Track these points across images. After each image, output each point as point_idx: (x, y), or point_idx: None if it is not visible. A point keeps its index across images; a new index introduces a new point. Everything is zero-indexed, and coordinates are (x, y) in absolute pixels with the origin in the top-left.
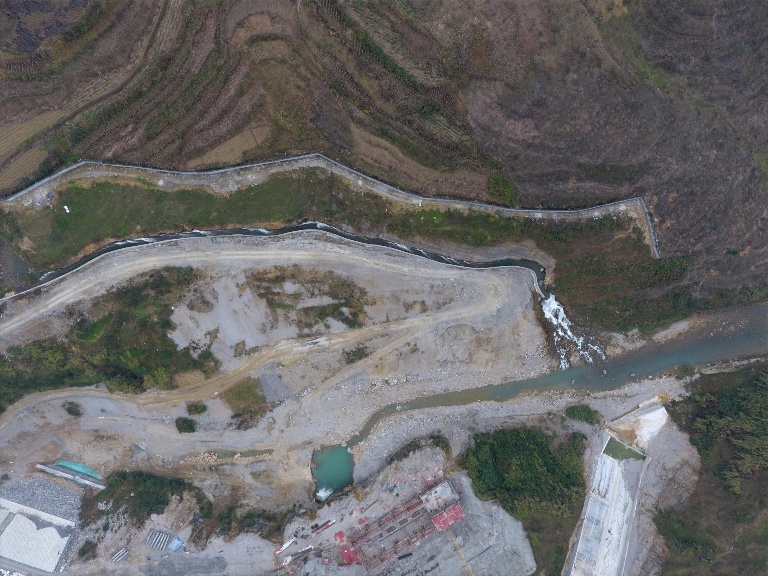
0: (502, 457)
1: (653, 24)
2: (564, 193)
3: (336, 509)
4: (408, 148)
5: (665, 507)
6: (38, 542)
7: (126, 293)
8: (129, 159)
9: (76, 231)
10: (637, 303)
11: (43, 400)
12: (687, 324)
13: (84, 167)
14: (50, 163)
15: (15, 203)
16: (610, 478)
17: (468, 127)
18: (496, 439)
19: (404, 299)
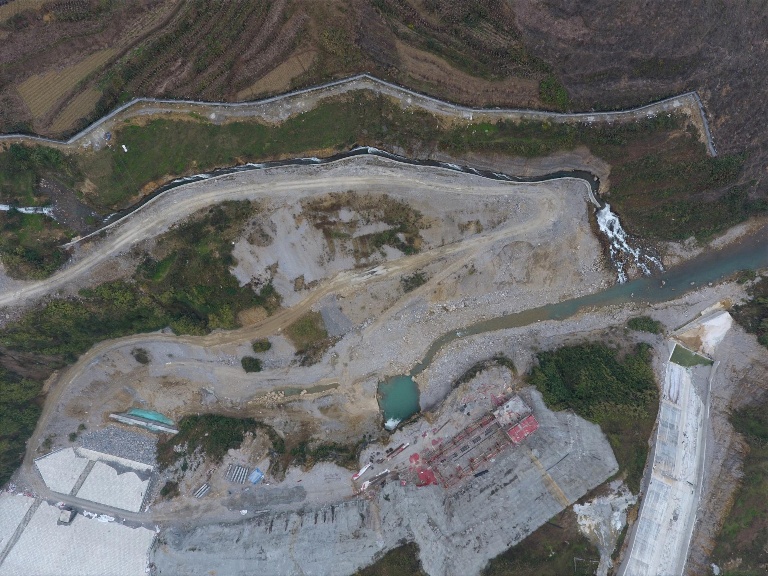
0: (569, 370)
1: None
2: (617, 93)
3: (408, 433)
4: (456, 60)
5: (740, 406)
6: (120, 486)
7: (188, 230)
8: (180, 94)
9: (135, 170)
10: (693, 207)
11: (112, 348)
12: (744, 228)
13: (138, 105)
14: (105, 102)
15: (75, 145)
16: (679, 384)
17: (516, 31)
18: (560, 356)
19: (459, 220)
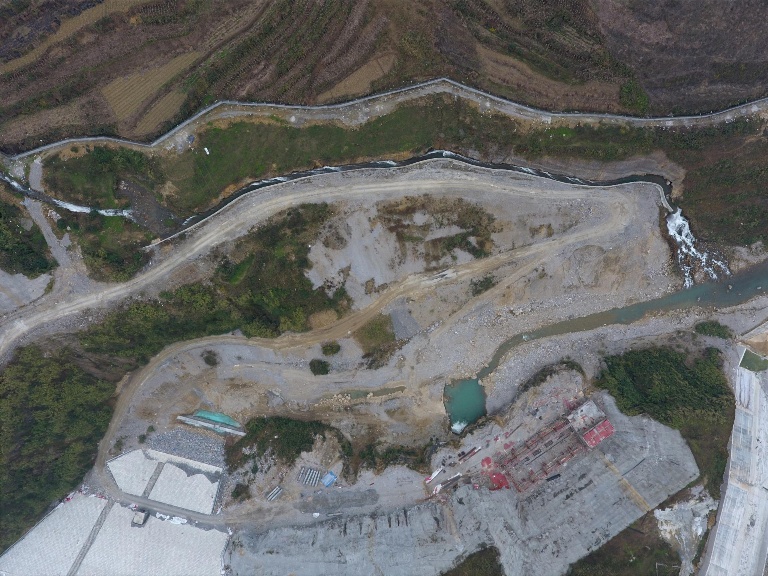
0: (641, 374)
1: None
2: (697, 97)
3: (480, 436)
4: (537, 64)
5: None
6: (191, 488)
7: (266, 233)
8: (262, 97)
9: (217, 173)
10: (764, 212)
11: (183, 350)
12: None
13: (220, 108)
14: (189, 105)
15: (158, 148)
16: (750, 389)
17: (600, 35)
18: (628, 360)
19: (531, 224)
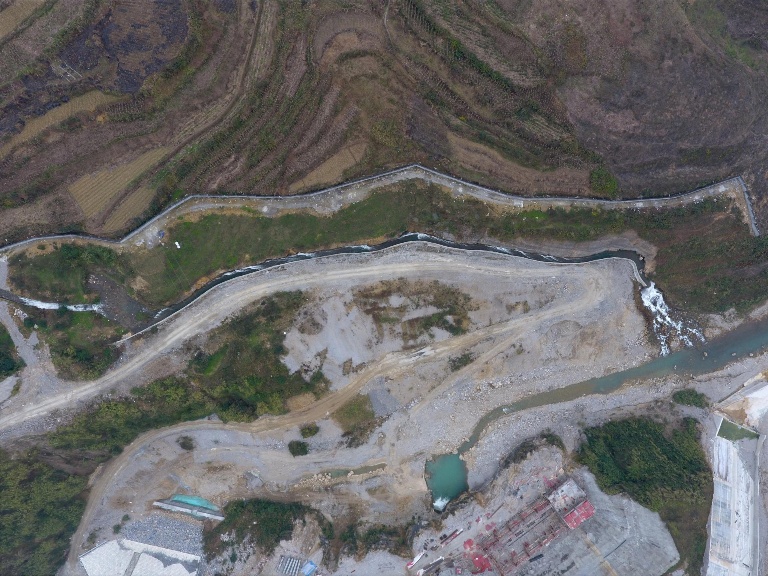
0: (620, 449)
1: (739, 3)
2: (665, 180)
3: (462, 518)
4: (507, 151)
5: None
6: None
7: (240, 323)
8: (233, 189)
9: (188, 266)
10: (735, 282)
11: (158, 437)
12: None
13: (191, 201)
14: (159, 201)
15: (127, 244)
16: (728, 460)
17: (568, 124)
18: (608, 432)
19: (507, 301)
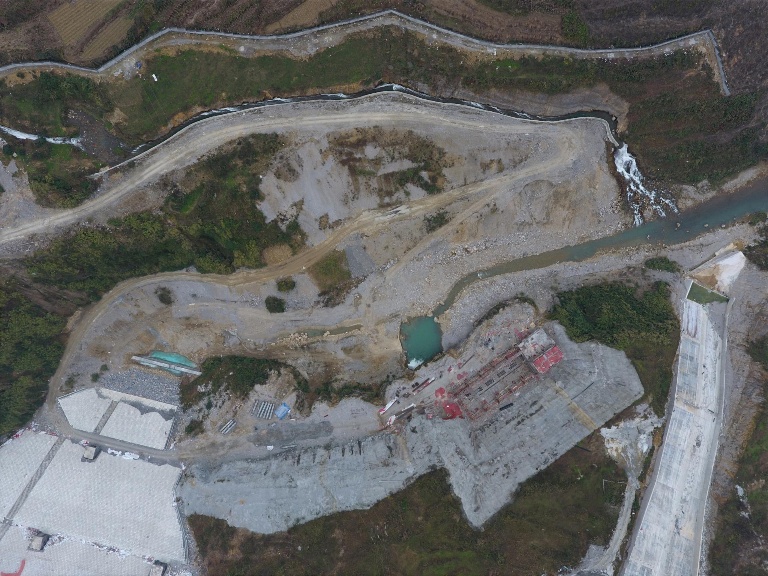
0: (591, 305)
1: None
2: (636, 29)
3: (434, 368)
4: None
5: (757, 338)
6: (144, 425)
7: (216, 162)
8: (210, 26)
9: (165, 100)
10: (707, 149)
11: (136, 286)
12: (755, 172)
13: (168, 35)
14: (137, 31)
15: (105, 74)
16: (697, 320)
17: None
18: (580, 294)
19: (481, 158)
